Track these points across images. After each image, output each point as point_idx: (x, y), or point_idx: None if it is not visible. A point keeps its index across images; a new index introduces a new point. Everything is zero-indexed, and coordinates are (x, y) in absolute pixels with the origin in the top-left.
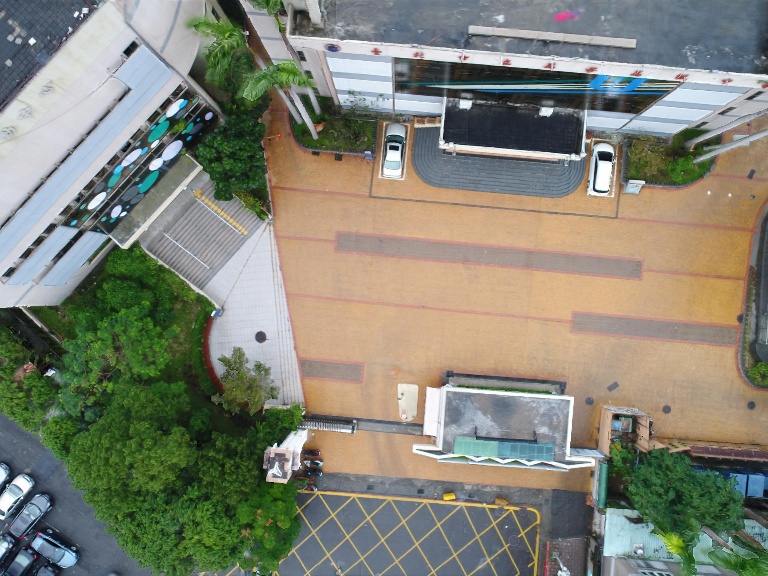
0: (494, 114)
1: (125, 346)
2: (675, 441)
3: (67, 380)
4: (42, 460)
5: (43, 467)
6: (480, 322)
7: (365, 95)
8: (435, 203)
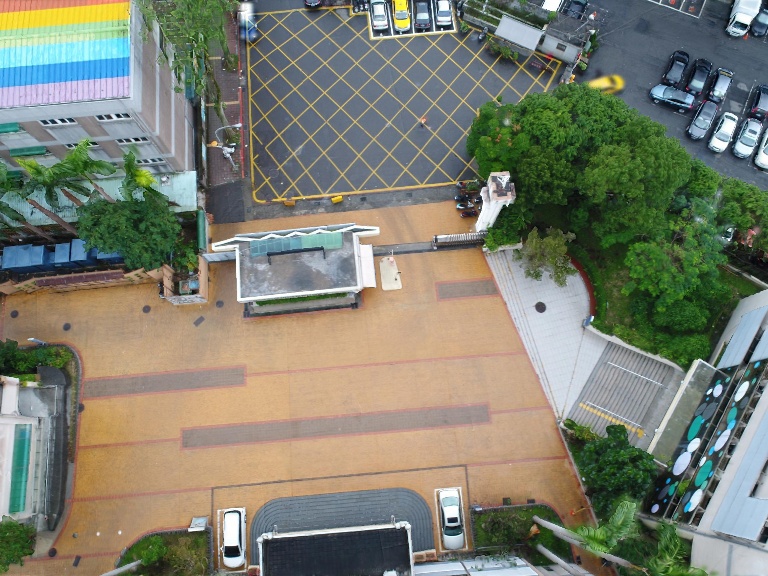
0: (358, 571)
1: (670, 263)
2: (137, 282)
3: (712, 226)
4: None
5: (705, 161)
6: (334, 359)
7: (497, 568)
8: (399, 471)
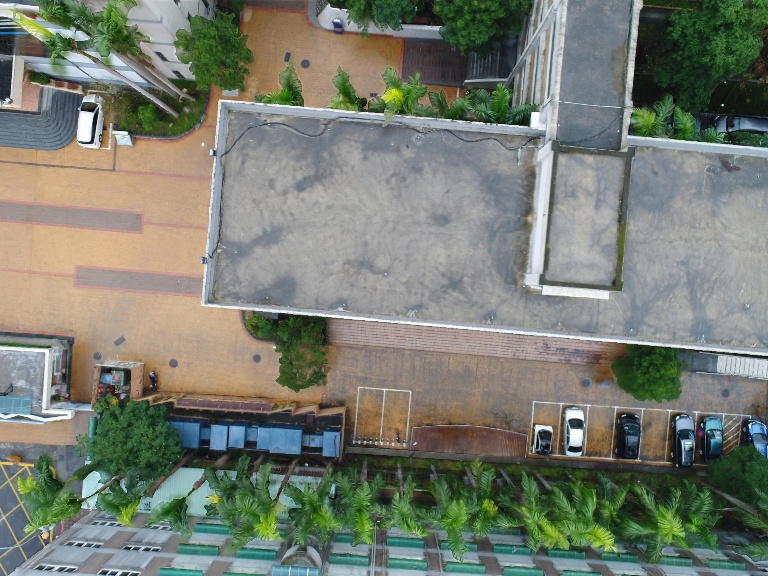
0: None
1: None
2: None
3: None
4: None
5: None
6: None
7: None
8: None
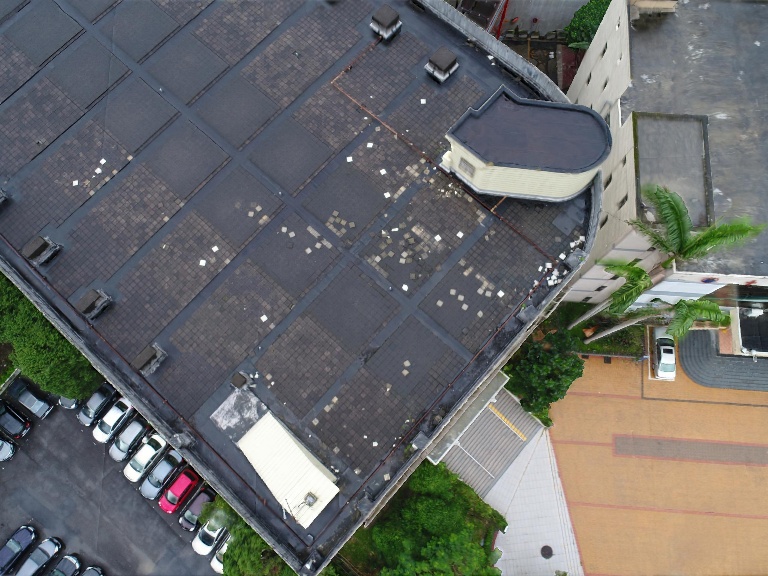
0: None
1: None
2: None
3: None
4: None
5: None
6: None
7: None
8: (709, 403)
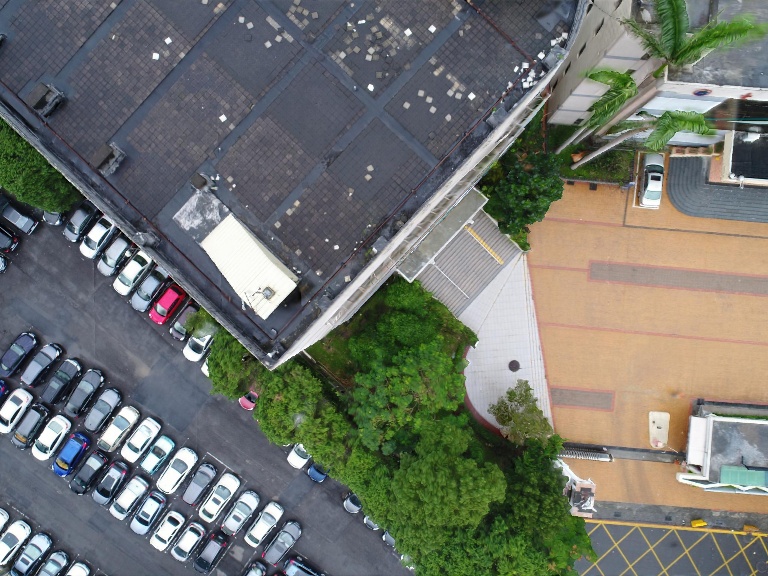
0: None
1: (433, 382)
2: None
3: (368, 415)
4: (290, 488)
5: (291, 495)
6: (732, 350)
7: None
8: (689, 232)
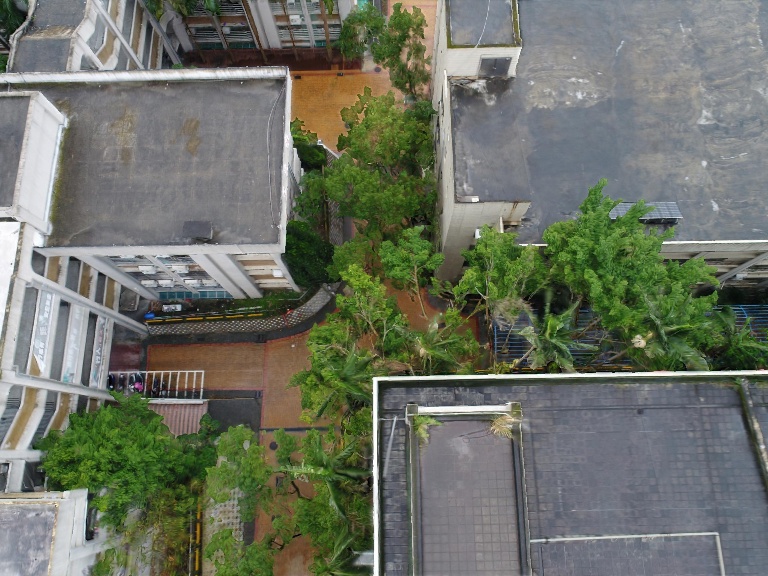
0: None
1: None
2: None
3: None
4: None
5: None
6: None
7: None
8: None
